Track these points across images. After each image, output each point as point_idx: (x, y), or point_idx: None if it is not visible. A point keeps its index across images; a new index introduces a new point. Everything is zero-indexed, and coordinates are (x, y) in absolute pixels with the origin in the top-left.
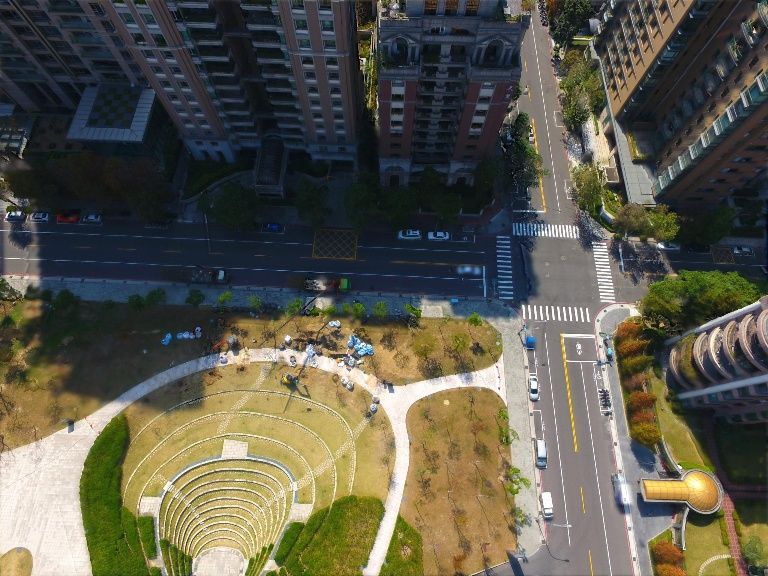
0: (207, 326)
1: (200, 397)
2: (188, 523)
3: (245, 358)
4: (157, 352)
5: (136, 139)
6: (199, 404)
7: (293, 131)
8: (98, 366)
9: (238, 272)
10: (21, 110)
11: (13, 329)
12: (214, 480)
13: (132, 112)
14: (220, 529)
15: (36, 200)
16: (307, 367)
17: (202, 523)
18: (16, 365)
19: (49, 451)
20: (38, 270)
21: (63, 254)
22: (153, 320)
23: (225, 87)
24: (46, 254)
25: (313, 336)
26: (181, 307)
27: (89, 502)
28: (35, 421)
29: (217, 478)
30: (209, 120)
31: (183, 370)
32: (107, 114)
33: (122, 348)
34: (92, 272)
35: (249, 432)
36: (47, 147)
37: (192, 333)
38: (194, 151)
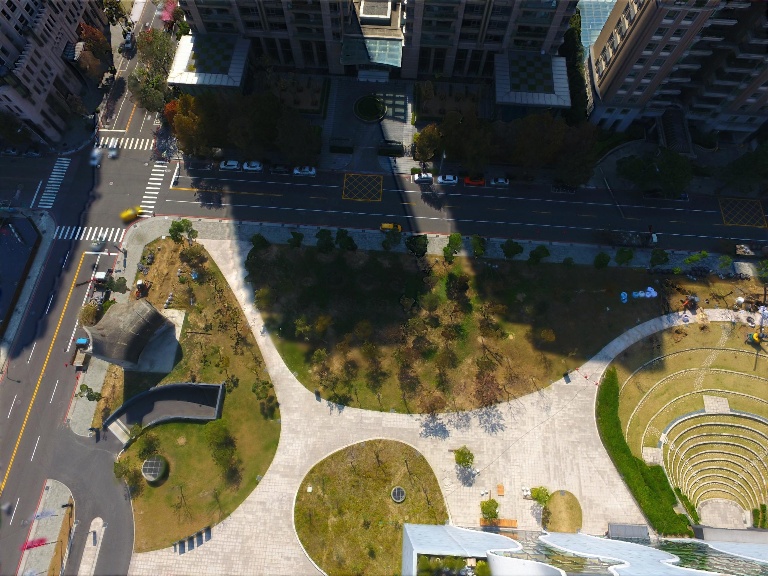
0: (653, 286)
1: (670, 354)
2: (684, 474)
3: (704, 317)
4: (619, 309)
5: (565, 104)
6: (670, 360)
7: (710, 100)
8: (567, 321)
9: (658, 237)
10: (397, 77)
11: (502, 282)
12: (701, 433)
13: (550, 78)
14: (712, 481)
15: (473, 160)
16: (765, 328)
17: (695, 475)
18: (485, 319)
19: (555, 400)
20: (461, 230)
21: (480, 215)
22: (595, 280)
23: (698, 52)
24: (464, 215)
25: (760, 298)
26: (615, 268)
27: (613, 449)
28: (530, 371)
29: (704, 432)
30: (650, 86)
31: (650, 327)
32: (527, 79)
33: (580, 305)
34: (517, 233)
35: (726, 388)
36: (437, 113)
37: (647, 292)
38: (594, 119)
